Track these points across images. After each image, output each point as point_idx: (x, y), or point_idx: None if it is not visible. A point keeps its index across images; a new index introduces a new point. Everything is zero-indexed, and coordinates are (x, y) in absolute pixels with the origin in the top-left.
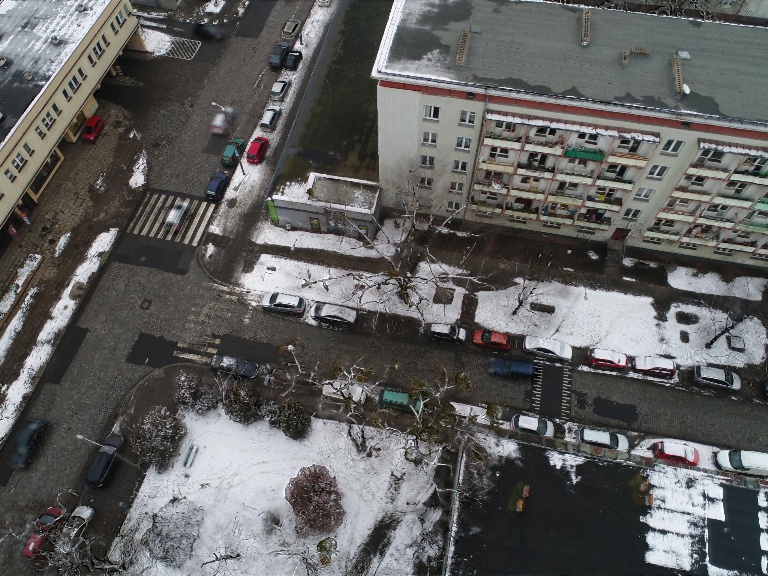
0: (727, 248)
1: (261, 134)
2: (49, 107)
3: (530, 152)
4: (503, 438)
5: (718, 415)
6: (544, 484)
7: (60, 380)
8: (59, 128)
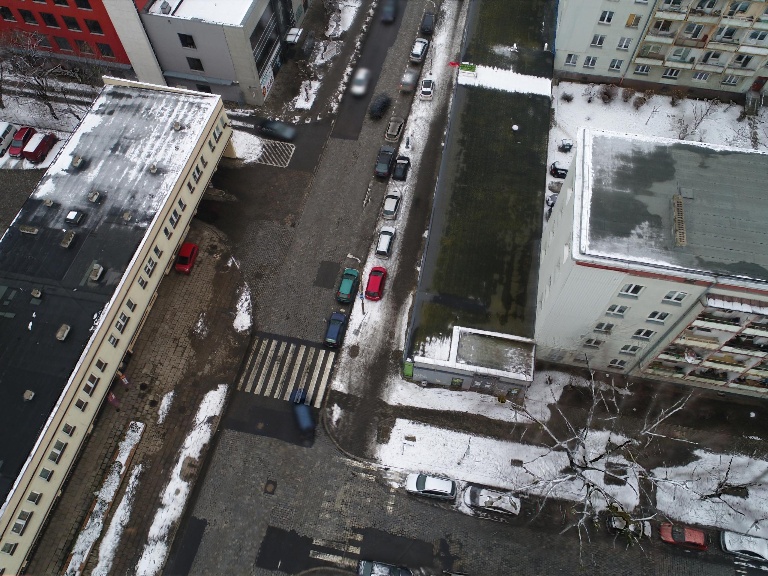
0: None
1: (376, 261)
2: (151, 251)
3: (749, 335)
4: None
5: None
6: None
7: None
8: (159, 270)
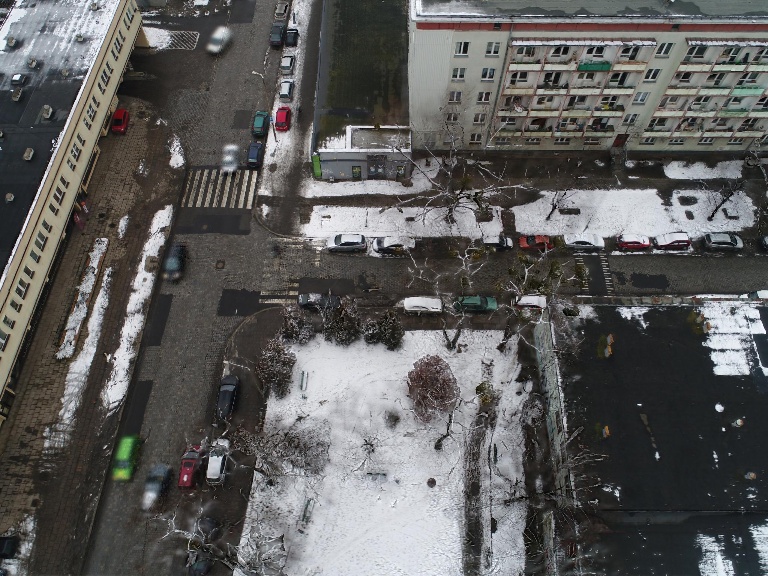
0: (710, 136)
1: (281, 105)
2: (90, 99)
3: (549, 72)
4: (579, 304)
5: (731, 270)
6: (621, 333)
7: (160, 341)
8: (99, 119)
